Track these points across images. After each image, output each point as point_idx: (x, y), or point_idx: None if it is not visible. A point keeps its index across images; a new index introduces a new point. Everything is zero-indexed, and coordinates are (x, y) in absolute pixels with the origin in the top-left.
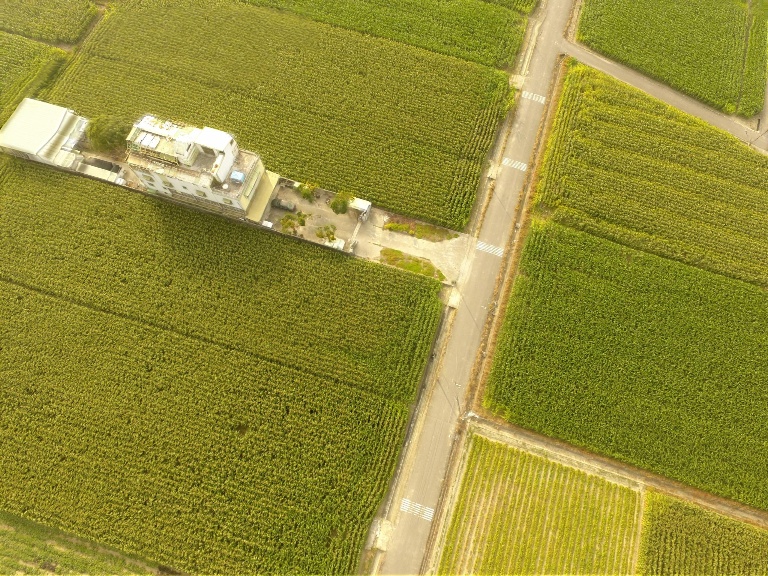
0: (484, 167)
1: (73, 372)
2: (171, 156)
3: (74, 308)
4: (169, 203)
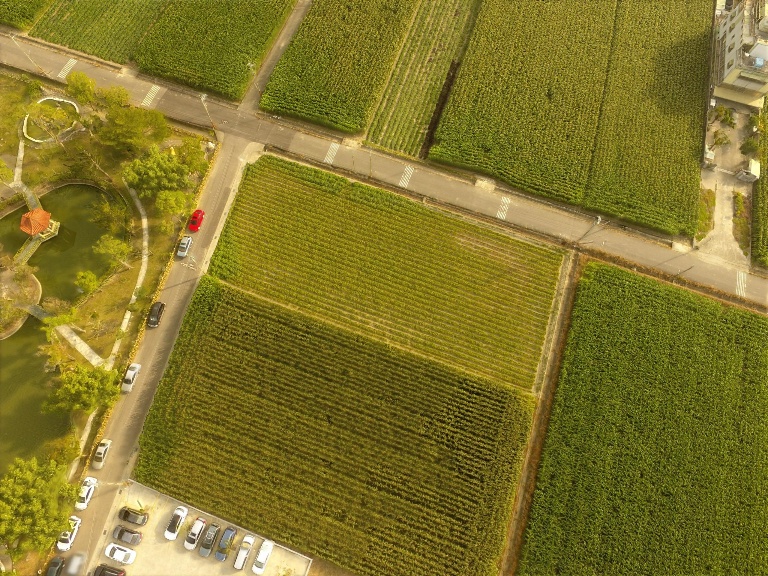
0: None
1: (572, 5)
2: (765, 13)
3: (614, 0)
4: (710, 42)
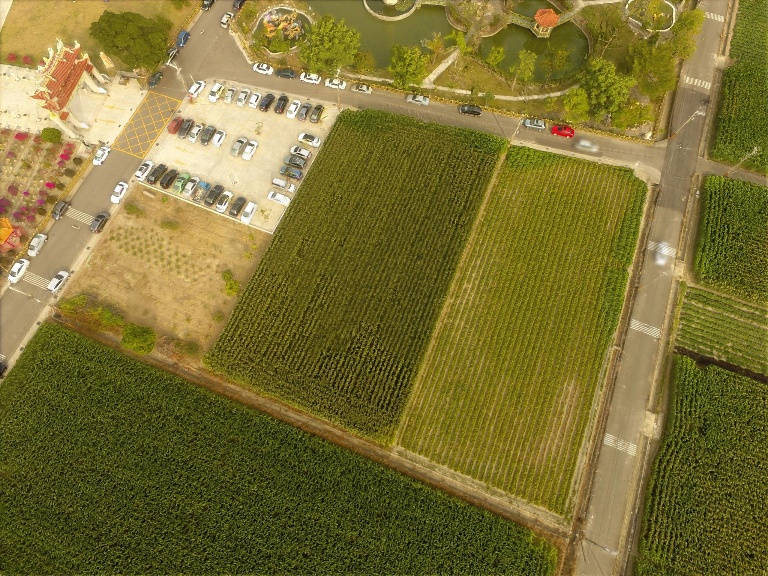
0: None
1: None
2: None
3: None
4: None
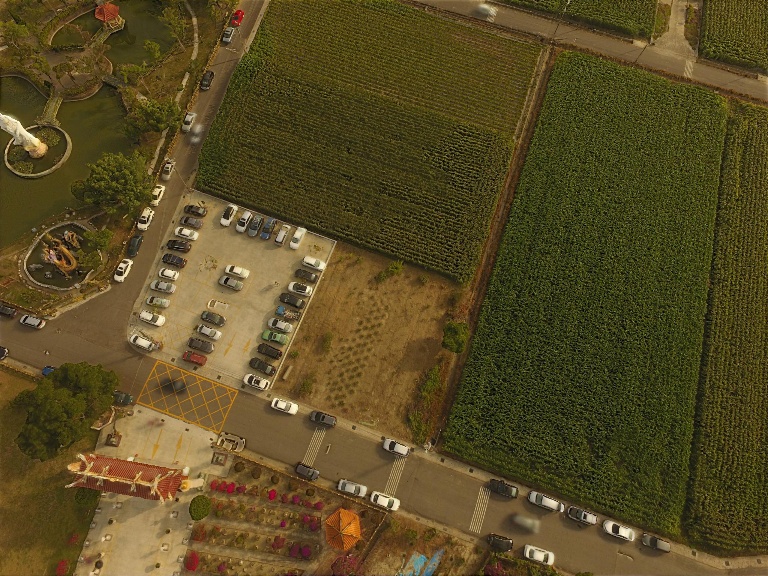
0: (767, 73)
1: None
2: None
3: None
4: None
